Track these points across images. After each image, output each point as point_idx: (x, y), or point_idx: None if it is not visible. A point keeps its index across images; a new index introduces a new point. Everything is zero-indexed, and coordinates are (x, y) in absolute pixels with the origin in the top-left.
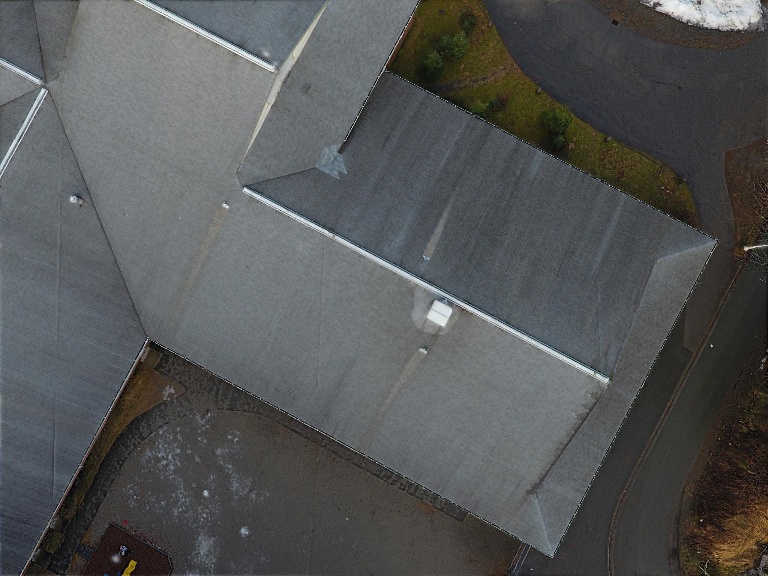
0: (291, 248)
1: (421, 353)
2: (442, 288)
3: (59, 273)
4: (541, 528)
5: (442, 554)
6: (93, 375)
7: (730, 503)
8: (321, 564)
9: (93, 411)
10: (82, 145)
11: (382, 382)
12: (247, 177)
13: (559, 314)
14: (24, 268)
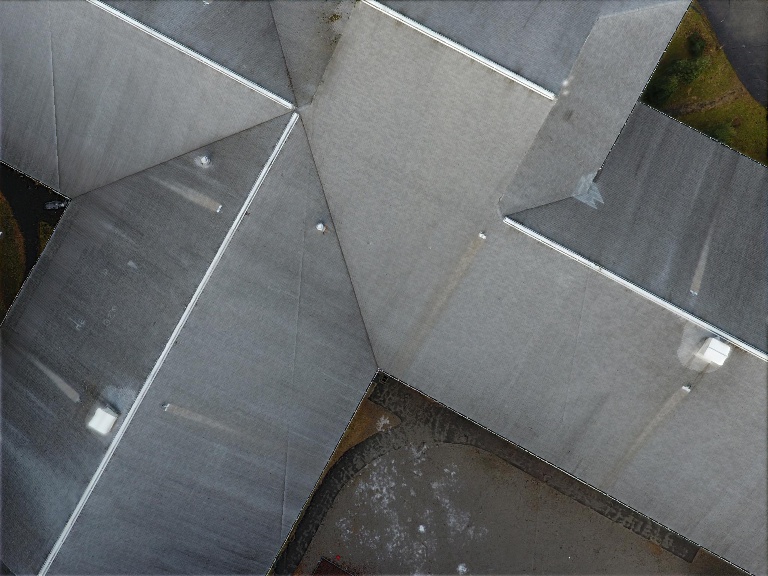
0: (550, 280)
1: (683, 391)
2: (714, 325)
3: (299, 302)
4: None
5: None
6: (325, 407)
7: None
8: None
9: (323, 444)
10: (330, 171)
11: (636, 420)
12: (508, 207)
13: None
14: (267, 297)
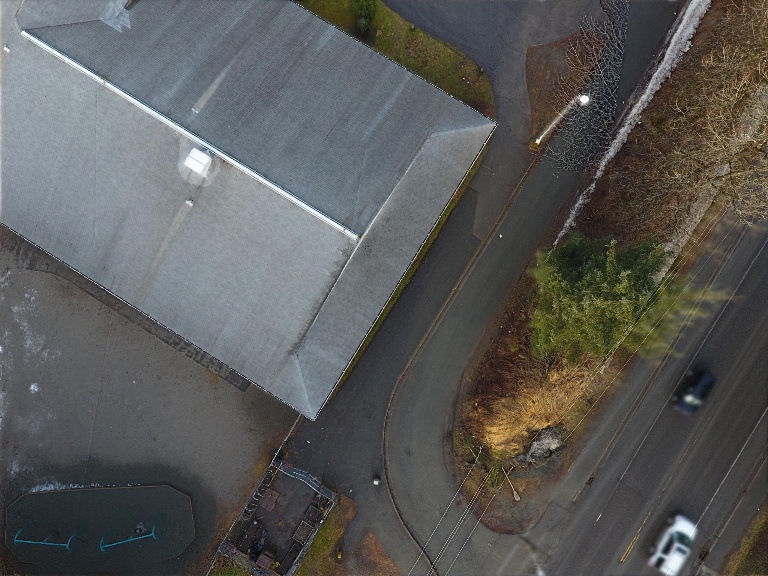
0: (67, 94)
1: (187, 205)
2: (205, 139)
3: None
4: (302, 390)
5: (223, 422)
6: None
7: (501, 386)
8: (105, 424)
9: None
10: None
11: (153, 235)
12: (27, 21)
13: (320, 174)
14: None
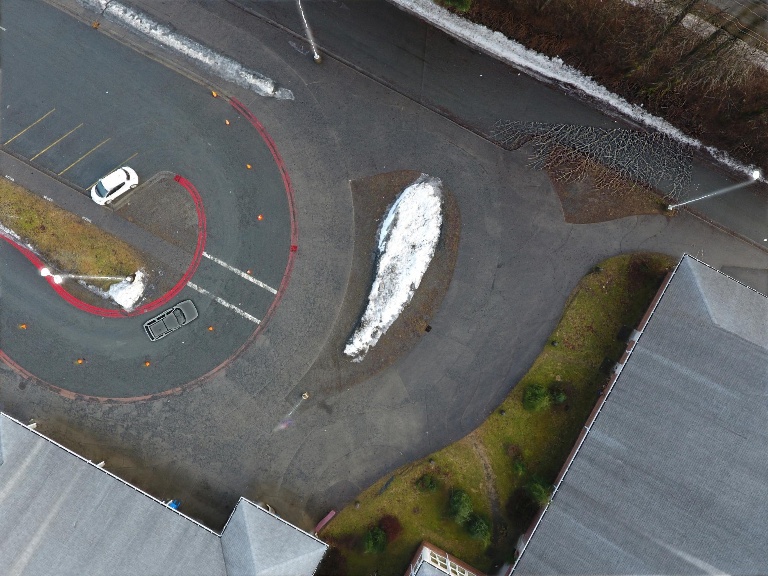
0: None
1: None
2: None
3: None
4: None
5: None
6: None
7: None
8: None
9: None
10: None
11: None
12: None
13: None
14: None
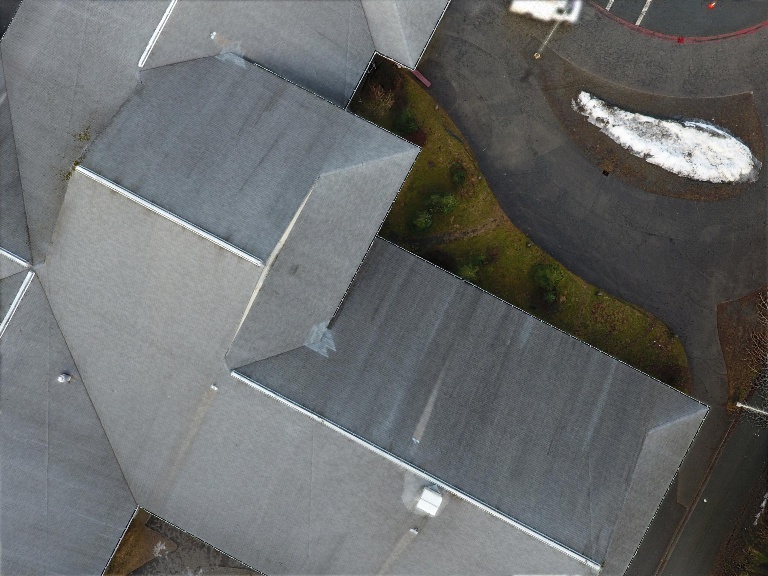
0: (280, 430)
1: (412, 533)
2: (432, 473)
3: (48, 449)
4: None
5: None
6: (83, 546)
7: None
8: None
9: None
10: (70, 325)
11: (373, 558)
12: (235, 361)
13: (550, 496)
14: (13, 447)
